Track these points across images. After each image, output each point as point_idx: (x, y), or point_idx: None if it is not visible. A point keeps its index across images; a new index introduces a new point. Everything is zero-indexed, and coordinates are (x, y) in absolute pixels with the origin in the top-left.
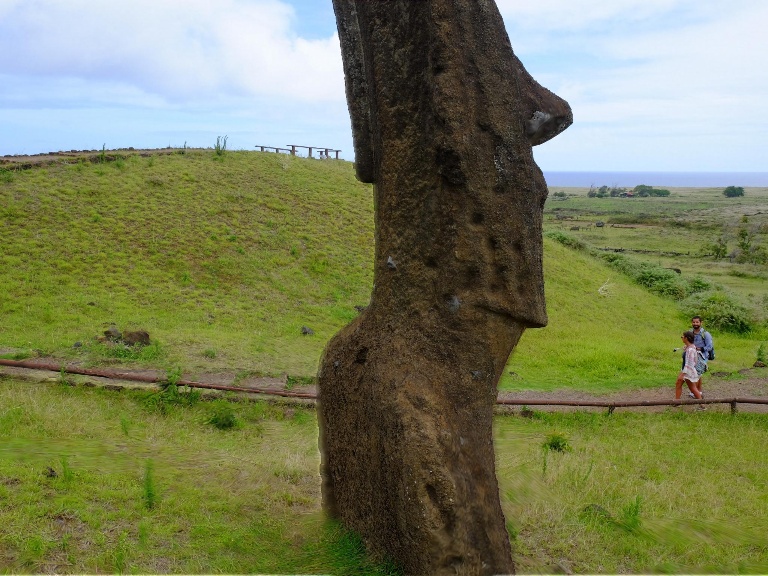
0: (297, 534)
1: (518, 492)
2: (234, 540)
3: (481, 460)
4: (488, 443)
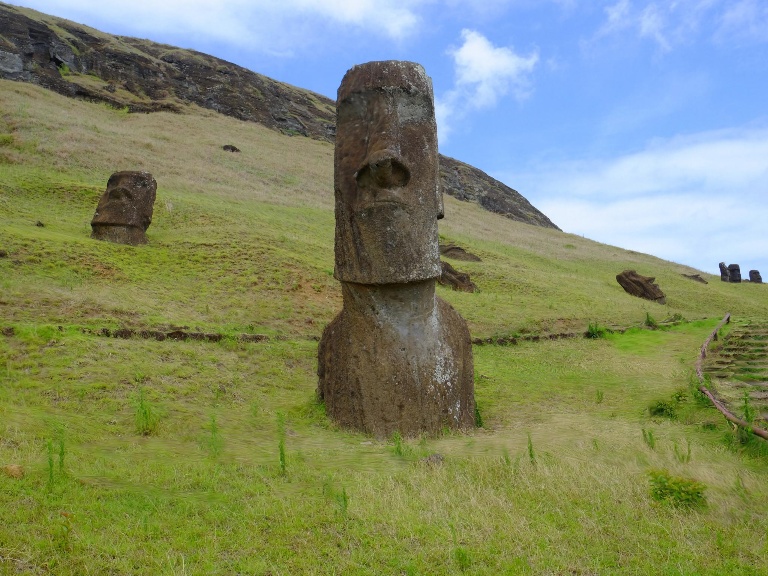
0: None
1: (478, 445)
2: None
3: (335, 344)
4: (347, 341)
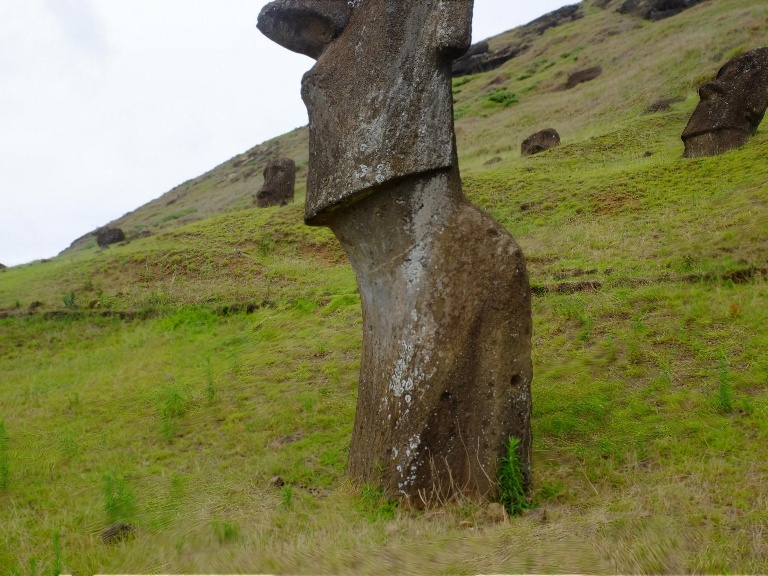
0: (547, 424)
1: (201, 534)
2: (600, 405)
3: None
4: None
